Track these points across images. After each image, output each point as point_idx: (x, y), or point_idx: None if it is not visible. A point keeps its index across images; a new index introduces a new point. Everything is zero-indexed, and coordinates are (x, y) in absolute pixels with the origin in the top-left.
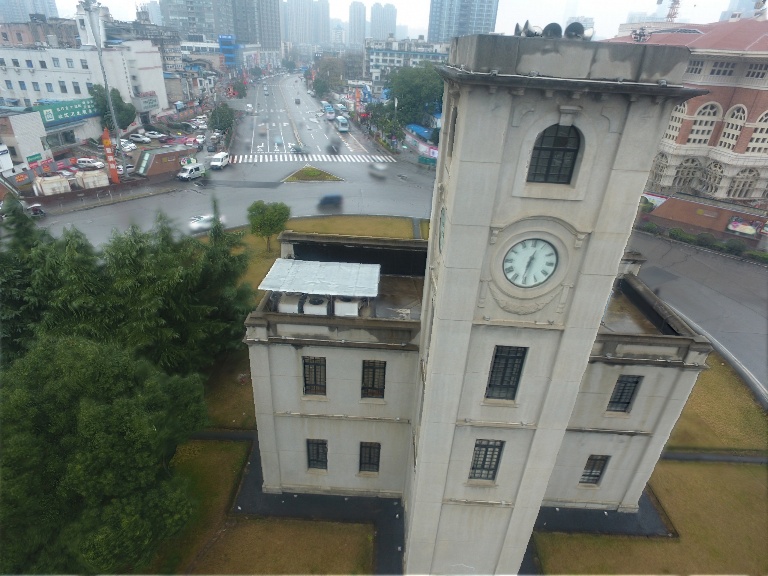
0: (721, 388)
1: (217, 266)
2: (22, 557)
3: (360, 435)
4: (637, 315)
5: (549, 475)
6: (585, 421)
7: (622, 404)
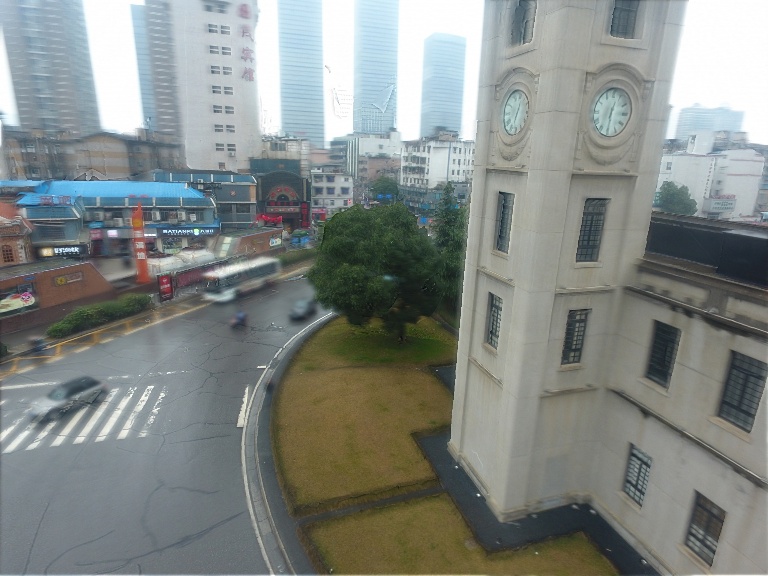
0: None
1: None
2: (337, 277)
3: None
4: None
5: (522, 352)
6: (686, 418)
7: (745, 416)
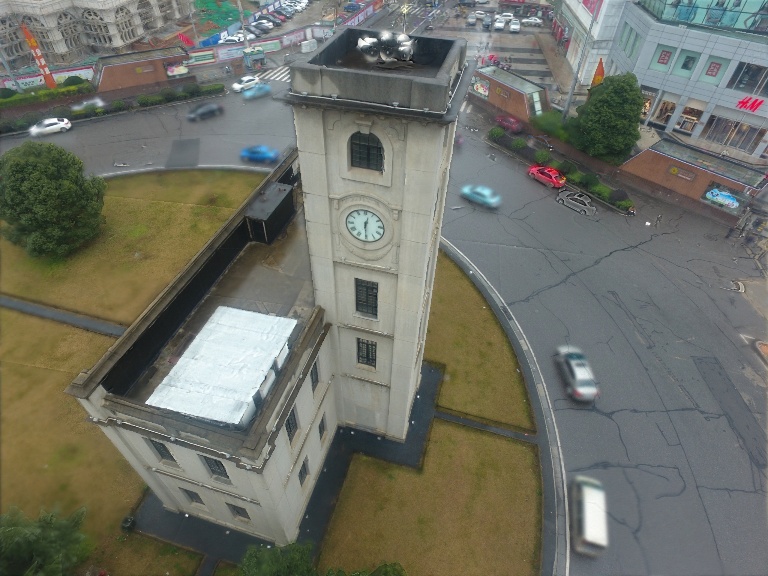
0: None
1: None
2: None
3: (317, 423)
4: None
5: None
6: None
7: None
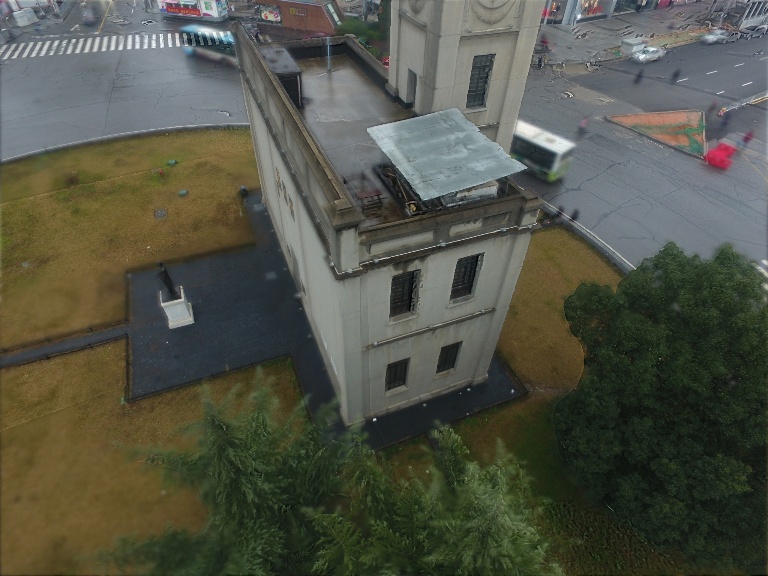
0: (207, 138)
1: (297, 484)
2: None
3: None
4: (303, 61)
5: None
6: None
7: None
